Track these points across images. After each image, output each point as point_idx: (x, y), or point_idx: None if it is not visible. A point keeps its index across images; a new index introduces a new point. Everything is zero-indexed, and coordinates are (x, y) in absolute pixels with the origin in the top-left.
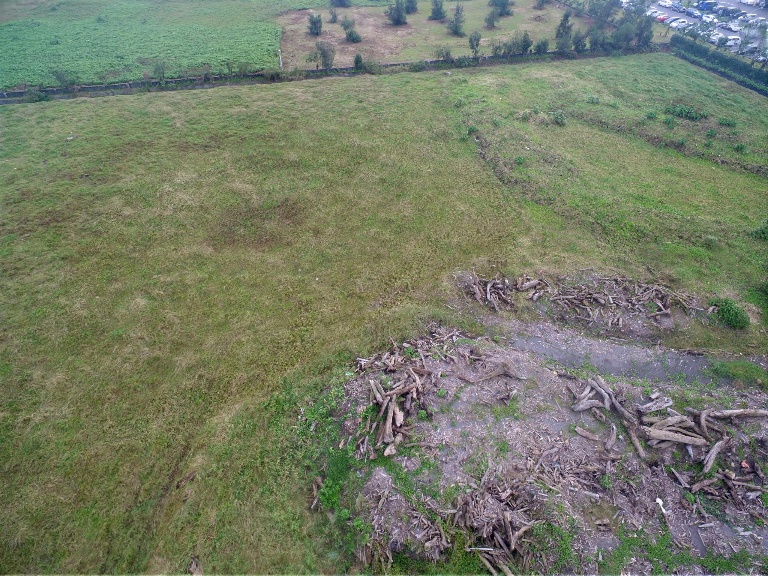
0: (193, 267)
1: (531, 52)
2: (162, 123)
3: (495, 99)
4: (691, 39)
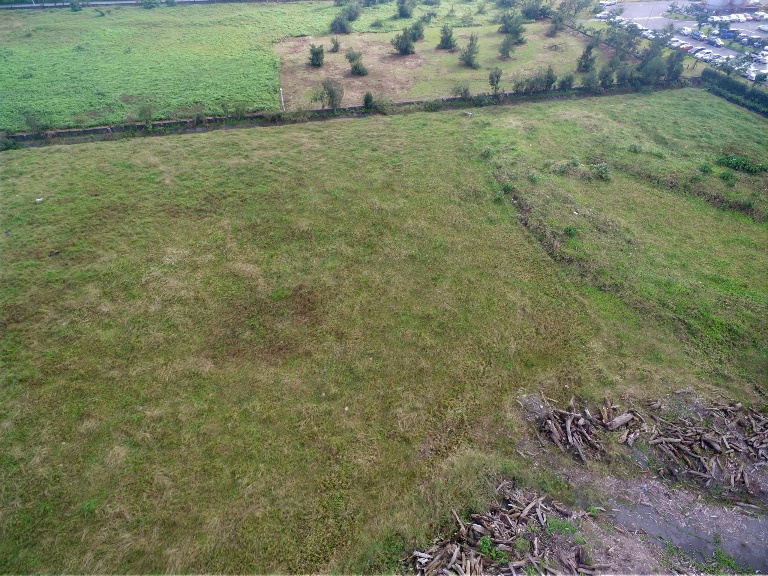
0: (188, 392)
1: (555, 88)
2: (148, 179)
3: (525, 146)
4: (724, 73)
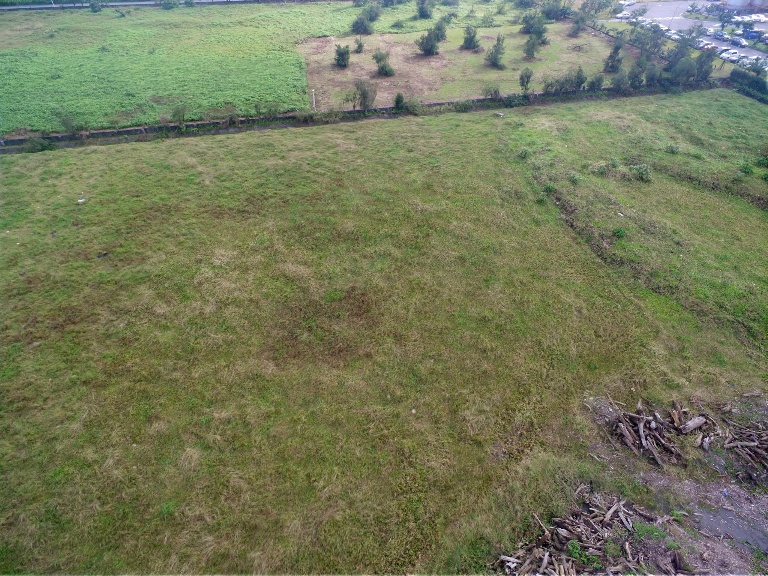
0: (253, 394)
1: (584, 89)
2: (188, 180)
3: (561, 147)
4: (754, 74)
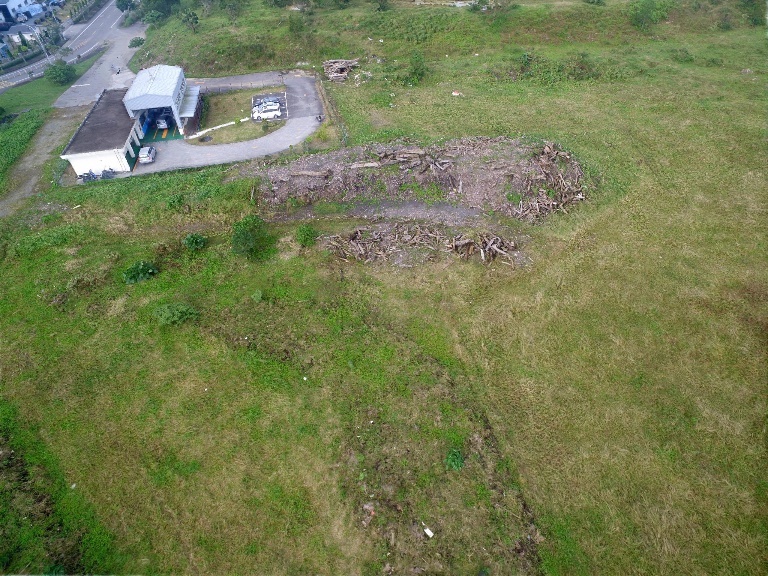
0: None
1: None
2: None
3: None
4: None
